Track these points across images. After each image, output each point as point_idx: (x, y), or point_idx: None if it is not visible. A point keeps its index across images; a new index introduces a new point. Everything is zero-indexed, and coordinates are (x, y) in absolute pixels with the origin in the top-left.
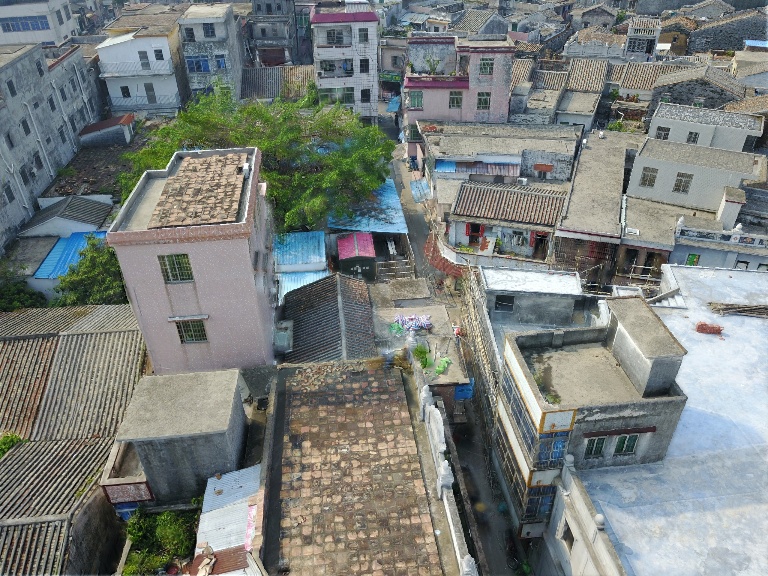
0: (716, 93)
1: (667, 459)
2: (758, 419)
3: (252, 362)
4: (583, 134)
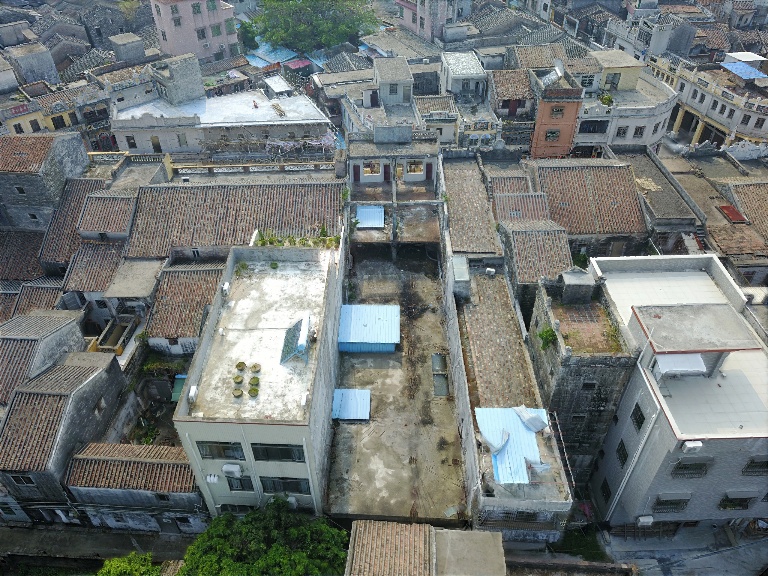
0: (516, 60)
1: (177, 107)
2: None
3: None
4: None
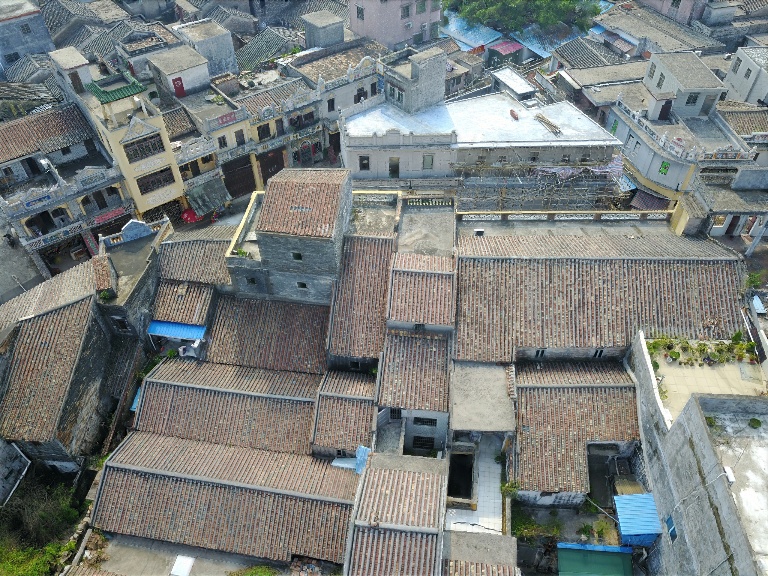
0: None
1: (414, 117)
2: (461, 132)
3: (373, 39)
4: (719, 52)
